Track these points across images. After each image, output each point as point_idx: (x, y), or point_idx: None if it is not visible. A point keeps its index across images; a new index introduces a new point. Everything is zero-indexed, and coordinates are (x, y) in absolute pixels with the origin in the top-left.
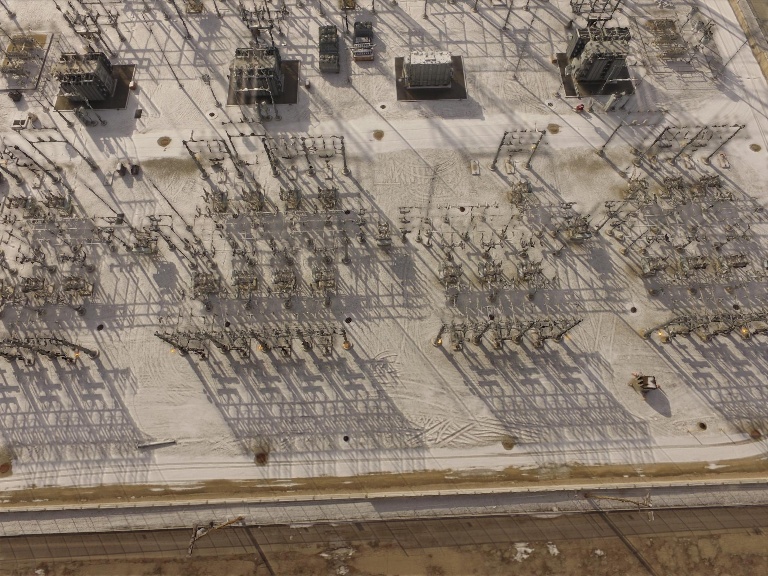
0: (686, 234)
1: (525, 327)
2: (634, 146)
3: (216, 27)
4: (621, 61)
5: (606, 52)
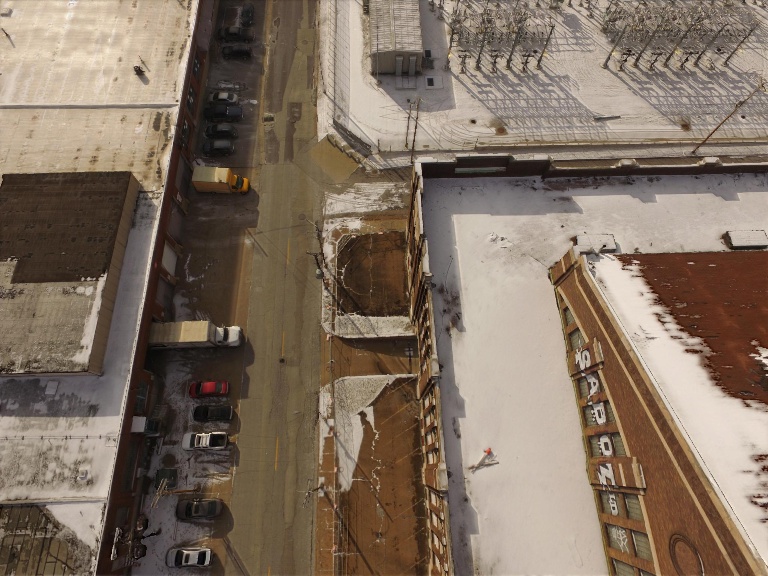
0: None
1: None
2: None
3: None
4: None
5: None
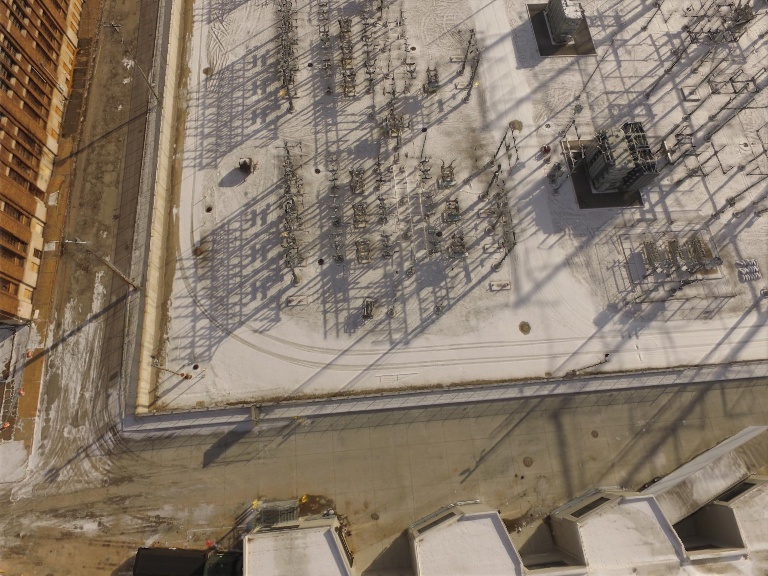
0: None
1: None
2: None
3: None
4: (603, 162)
5: (610, 143)
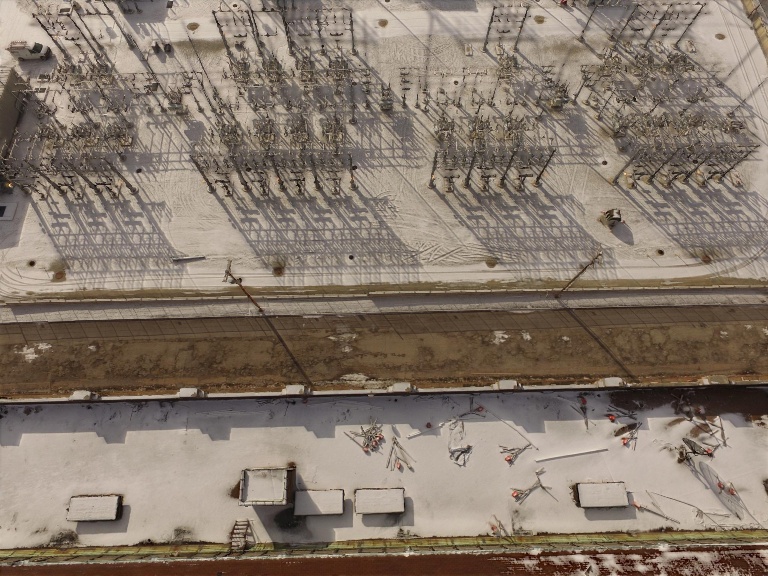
0: (652, 96)
1: (507, 161)
2: (611, 34)
3: None
4: None
5: None
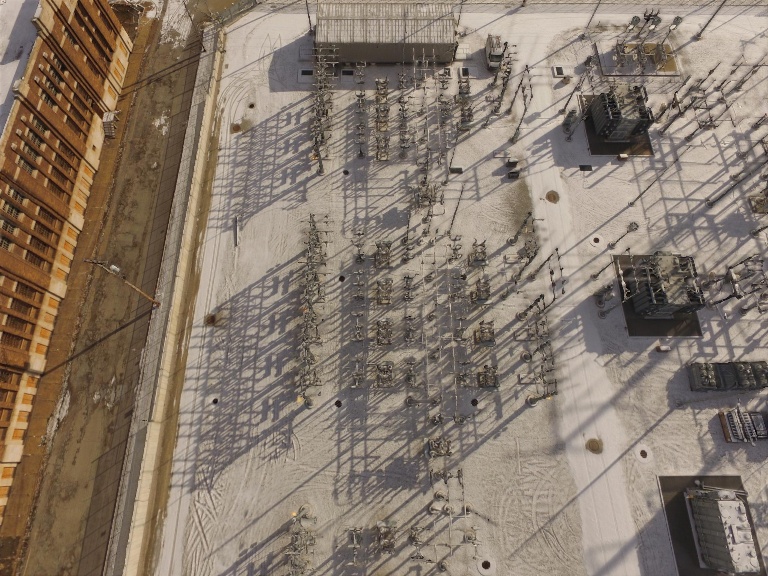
0: None
1: None
2: None
3: (734, 232)
4: None
5: None
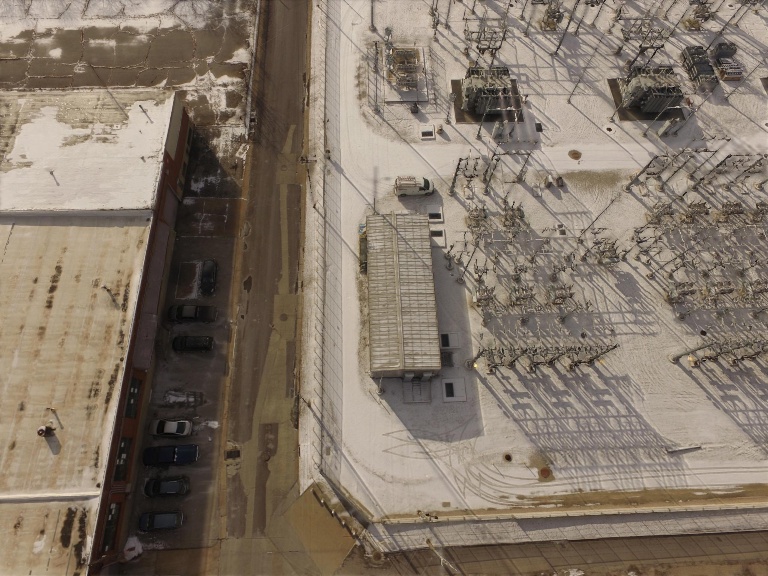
0: None
1: None
2: None
3: (576, 45)
4: None
5: None
